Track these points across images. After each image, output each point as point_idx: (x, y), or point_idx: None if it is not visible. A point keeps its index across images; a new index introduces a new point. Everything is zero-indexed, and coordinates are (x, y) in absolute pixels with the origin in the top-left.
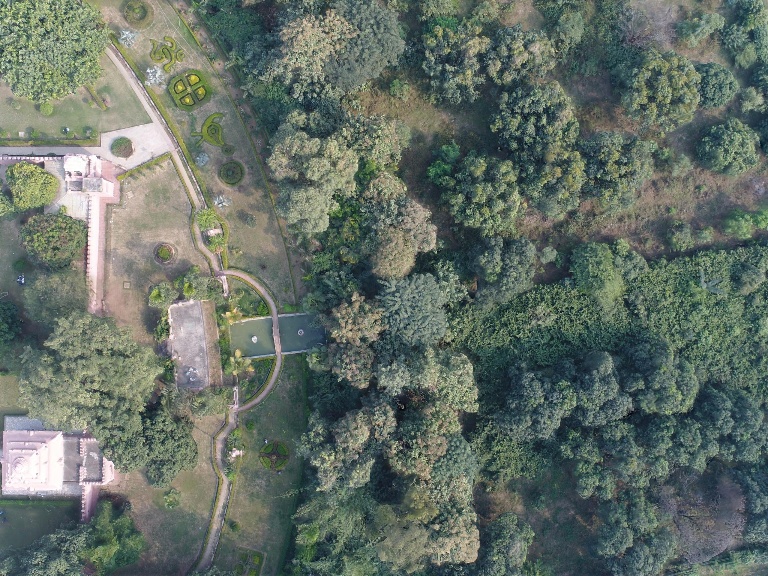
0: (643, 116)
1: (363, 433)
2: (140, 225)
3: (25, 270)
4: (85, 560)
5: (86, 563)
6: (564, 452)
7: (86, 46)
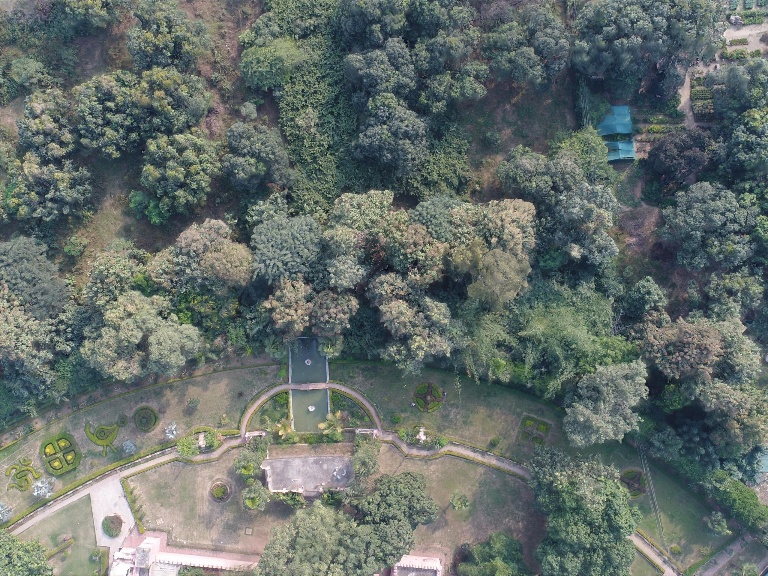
0: (115, 6)
1: (398, 307)
2: (191, 514)
3: None
4: None
5: None
6: (439, 109)
7: (4, 554)
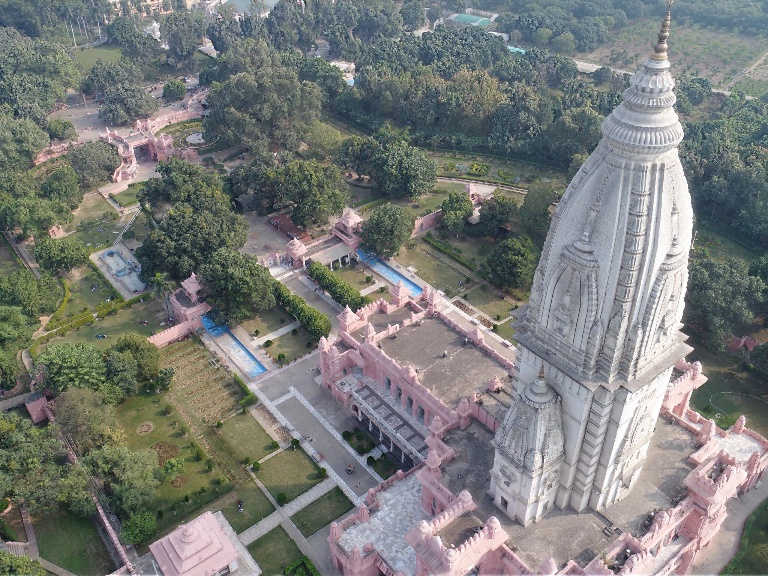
0: None
1: None
2: None
3: (488, 253)
4: None
5: None
6: None
7: None
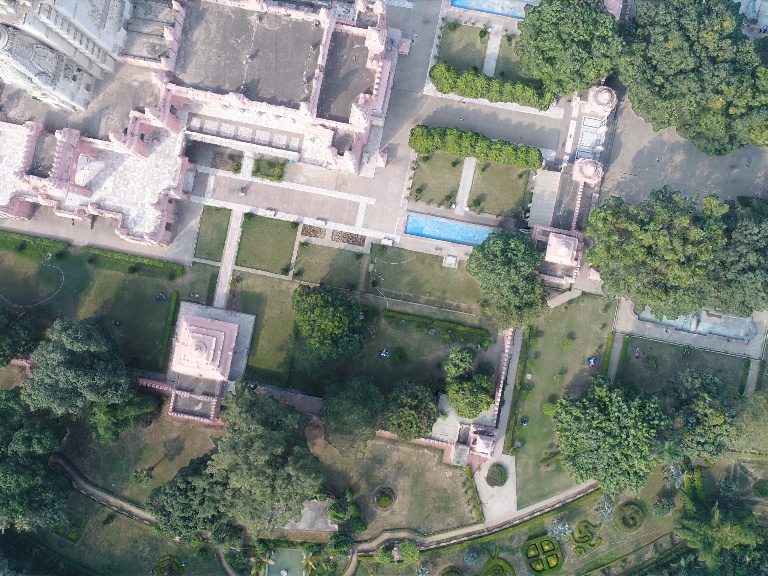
0: None
1: None
2: (418, 478)
3: None
4: (96, 402)
5: None
6: None
7: None
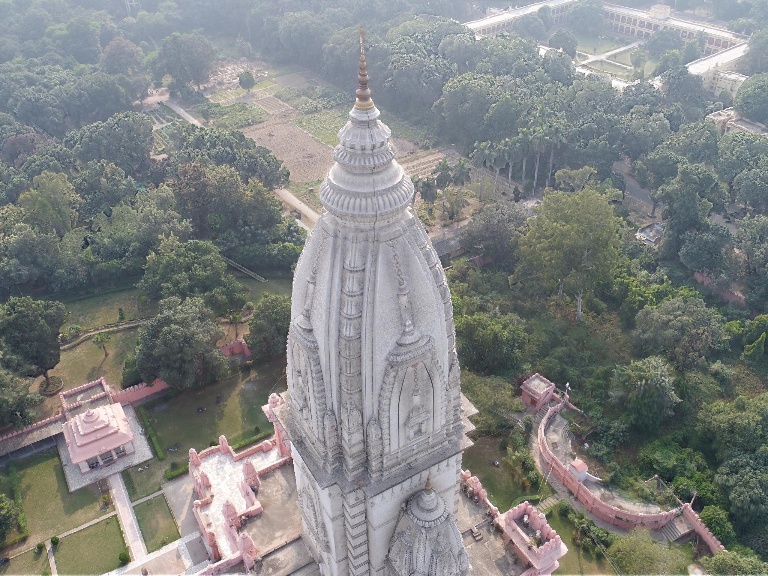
0: None
1: None
2: None
3: None
4: None
5: None
6: (1, 196)
7: None
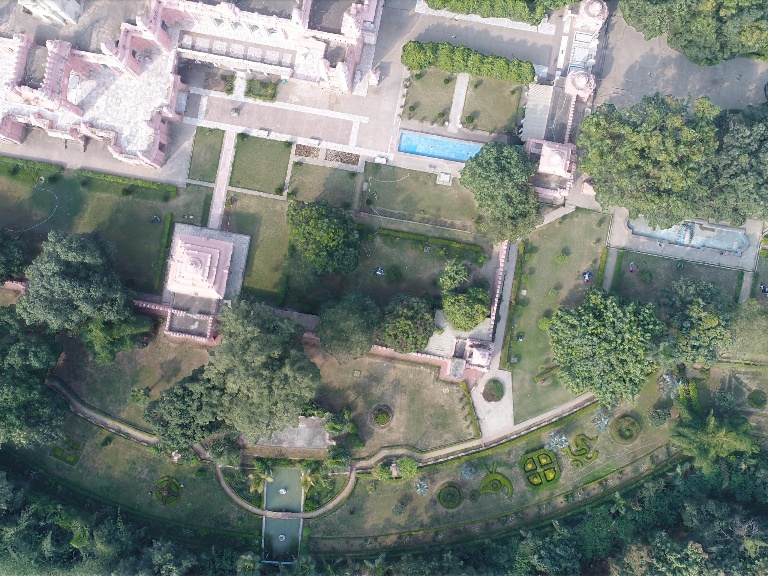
0: None
1: None
2: (415, 395)
3: None
4: (92, 318)
5: (88, 321)
6: None
7: None
